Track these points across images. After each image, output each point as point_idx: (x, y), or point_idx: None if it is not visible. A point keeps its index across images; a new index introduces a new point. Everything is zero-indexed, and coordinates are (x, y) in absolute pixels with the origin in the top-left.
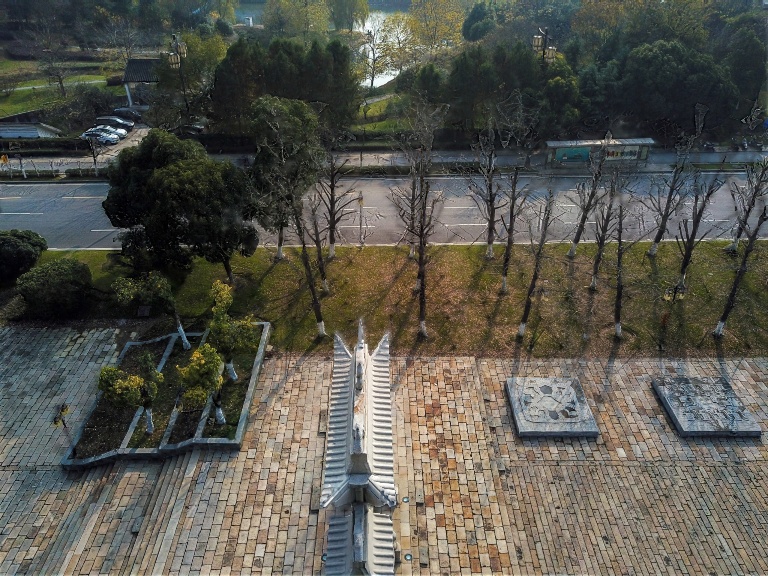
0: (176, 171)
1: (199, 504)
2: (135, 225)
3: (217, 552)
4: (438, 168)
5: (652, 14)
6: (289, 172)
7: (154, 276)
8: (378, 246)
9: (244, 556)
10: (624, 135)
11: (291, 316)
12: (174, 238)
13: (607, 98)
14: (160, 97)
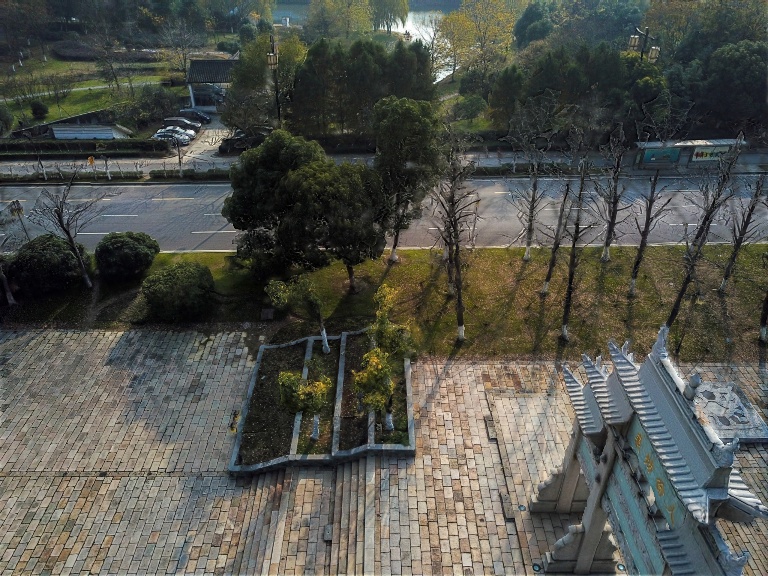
0: (312, 173)
1: (390, 512)
2: (257, 227)
3: (424, 561)
4: (525, 169)
5: (733, 13)
6: (412, 174)
7: (303, 279)
8: (488, 248)
9: (452, 566)
10: (706, 136)
11: (423, 319)
12: (313, 241)
13: (692, 98)
14: (248, 98)
